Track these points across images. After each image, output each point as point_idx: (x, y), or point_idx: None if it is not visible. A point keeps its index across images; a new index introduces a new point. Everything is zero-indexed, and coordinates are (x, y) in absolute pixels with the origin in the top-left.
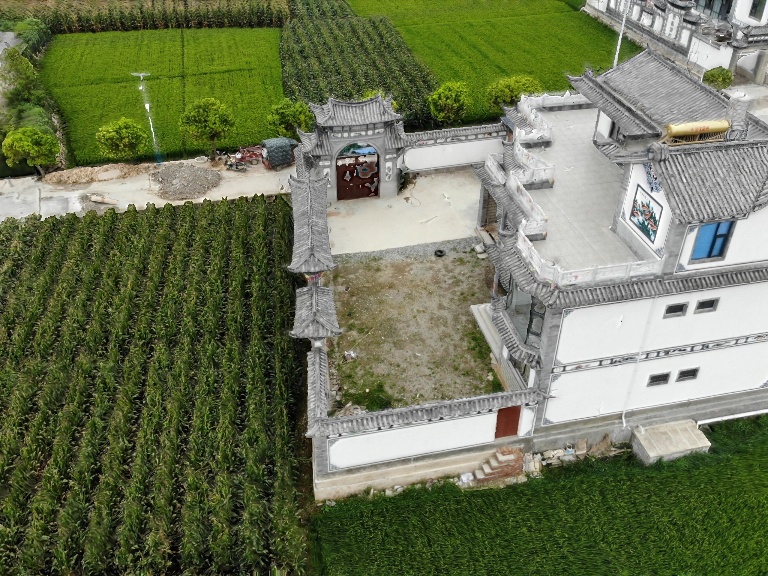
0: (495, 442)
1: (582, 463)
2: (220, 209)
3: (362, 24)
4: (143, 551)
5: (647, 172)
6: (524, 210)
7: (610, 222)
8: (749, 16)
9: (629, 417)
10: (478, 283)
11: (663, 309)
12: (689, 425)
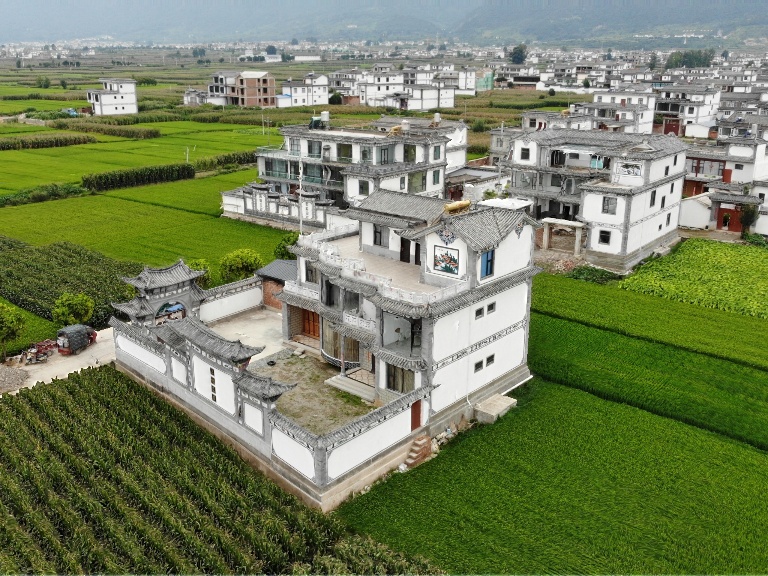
0: (412, 434)
1: (459, 436)
2: (62, 383)
3: (50, 248)
4: (241, 574)
5: (440, 235)
6: (367, 283)
7: (415, 280)
8: (359, 194)
9: (470, 399)
10: (315, 370)
11: (474, 313)
12: (499, 396)
